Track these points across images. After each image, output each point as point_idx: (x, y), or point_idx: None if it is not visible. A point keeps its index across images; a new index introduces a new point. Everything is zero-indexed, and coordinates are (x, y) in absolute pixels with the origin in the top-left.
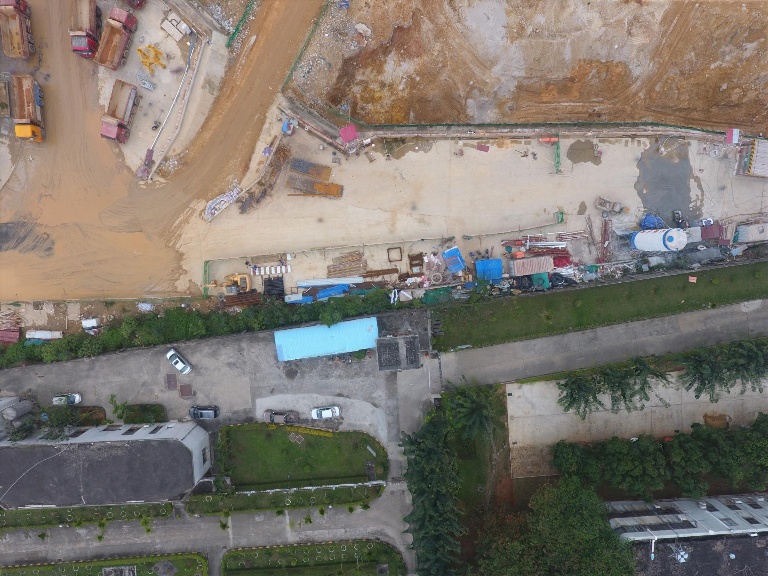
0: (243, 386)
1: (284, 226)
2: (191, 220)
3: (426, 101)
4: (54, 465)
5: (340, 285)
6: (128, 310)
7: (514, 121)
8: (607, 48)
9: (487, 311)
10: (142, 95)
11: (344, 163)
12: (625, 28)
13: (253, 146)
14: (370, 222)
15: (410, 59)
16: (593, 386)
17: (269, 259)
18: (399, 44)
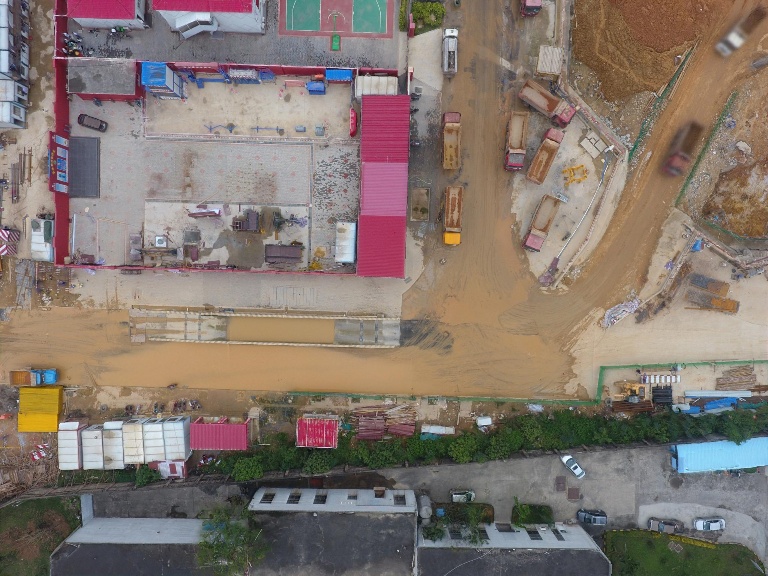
0: (629, 492)
1: (677, 337)
2: (589, 327)
3: None
4: (475, 568)
5: (729, 398)
6: (517, 410)
7: None
8: None
9: None
10: None
11: (742, 280)
12: None
13: (649, 258)
14: (762, 338)
15: None
16: None
17: (660, 368)
18: (764, 159)
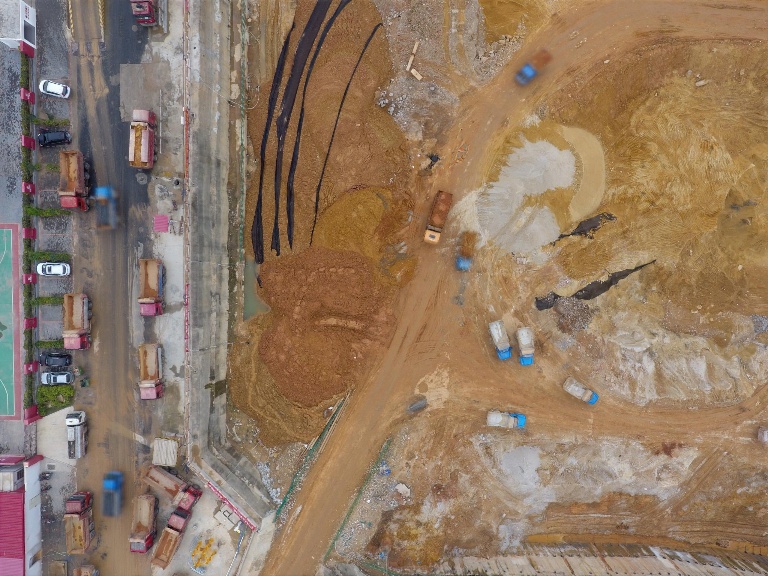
0: None
1: None
2: None
3: (460, 540)
4: None
5: None
6: None
7: (543, 529)
8: (637, 489)
9: None
10: None
11: None
12: (655, 478)
13: None
14: None
15: (446, 500)
16: None
17: None
18: (436, 487)
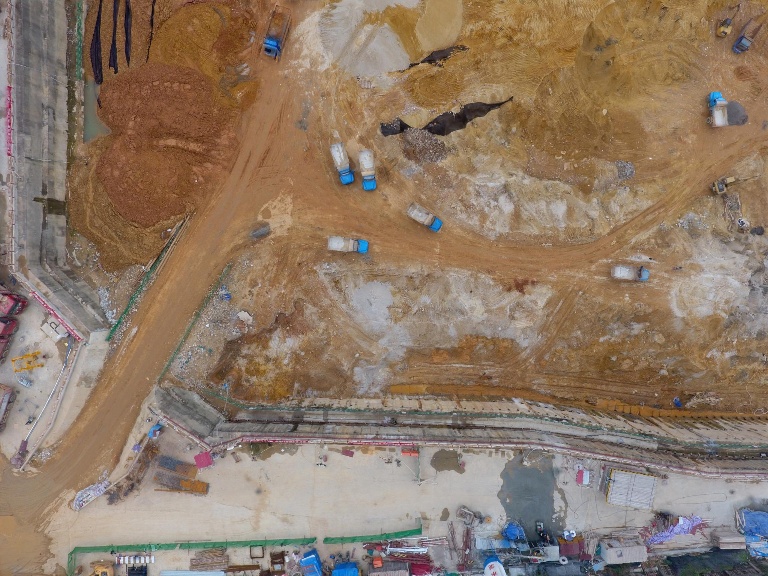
0: None
1: (150, 518)
2: (60, 509)
3: (309, 376)
4: None
5: None
6: None
7: (405, 379)
8: (491, 329)
9: None
10: (19, 390)
11: None
12: (507, 315)
13: (126, 437)
14: (234, 519)
15: (295, 335)
16: None
17: (134, 549)
18: (285, 322)
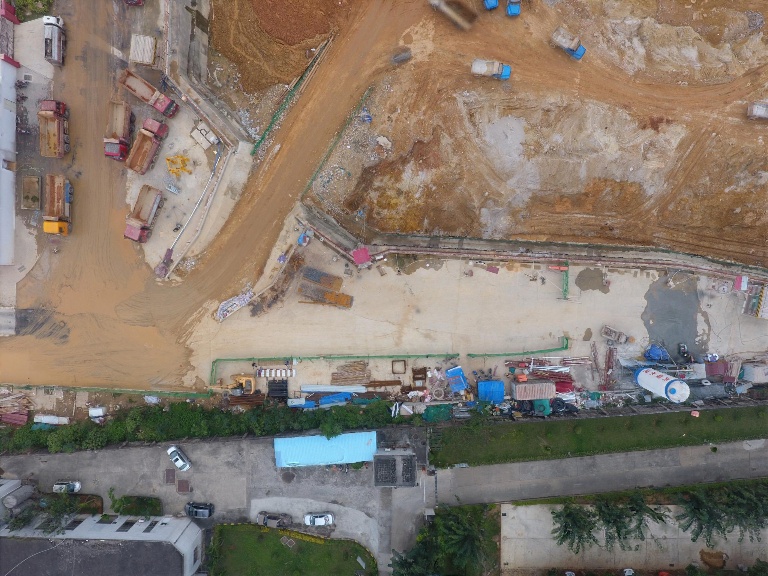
0: (239, 486)
1: (293, 331)
2: (203, 319)
3: (441, 210)
4: (48, 558)
5: (343, 393)
6: (134, 401)
7: (527, 229)
8: (622, 170)
9: (486, 430)
10: (167, 198)
11: (356, 275)
12: (641, 153)
13: (269, 251)
14: (377, 333)
15: (428, 169)
16: (587, 524)
17: (275, 362)
18: (418, 155)
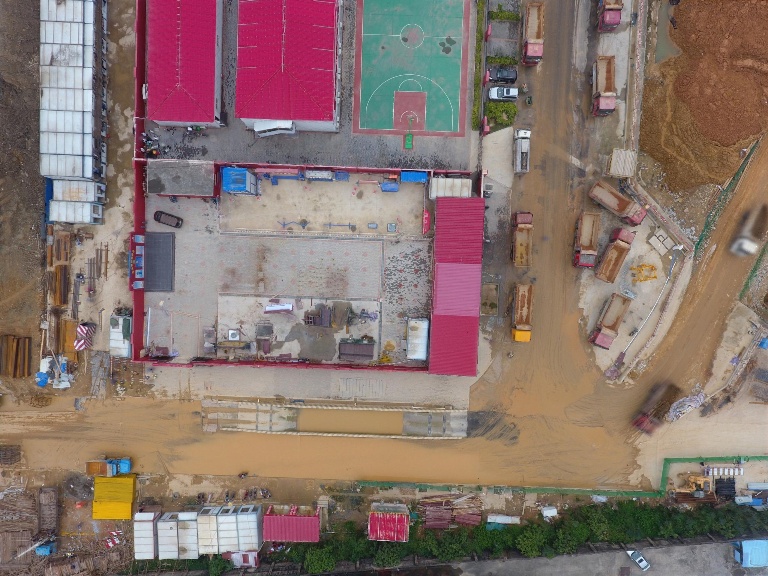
0: None
1: (741, 431)
2: (654, 420)
3: None
4: None
5: None
6: (581, 500)
7: None
8: None
9: None
10: None
11: None
12: None
13: (713, 351)
14: None
15: None
16: None
17: (723, 461)
18: None
